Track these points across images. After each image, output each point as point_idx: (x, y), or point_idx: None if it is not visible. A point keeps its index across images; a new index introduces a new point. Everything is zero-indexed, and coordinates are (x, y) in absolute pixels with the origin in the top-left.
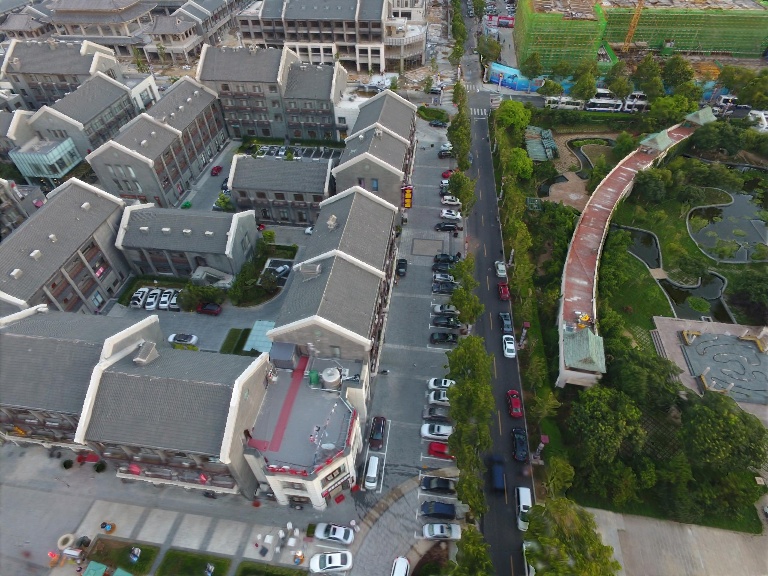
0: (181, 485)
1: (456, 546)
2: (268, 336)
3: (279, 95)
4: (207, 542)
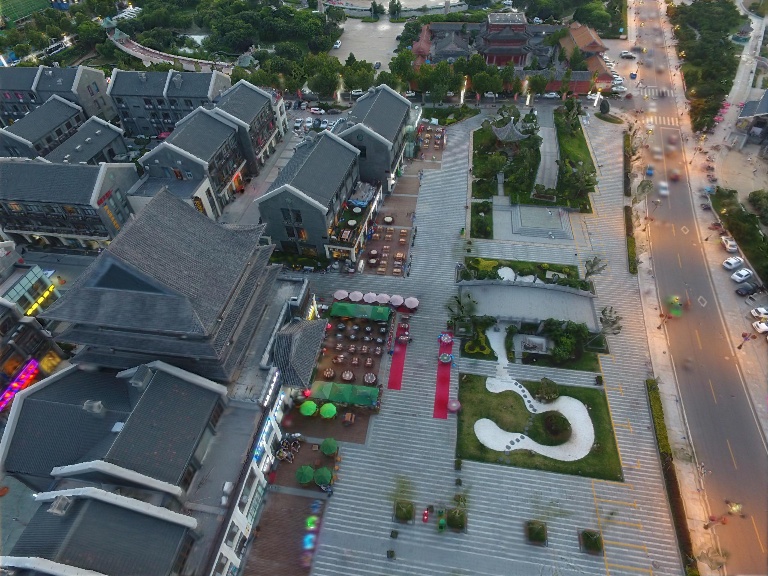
0: None
1: None
2: (210, 97)
3: None
4: None
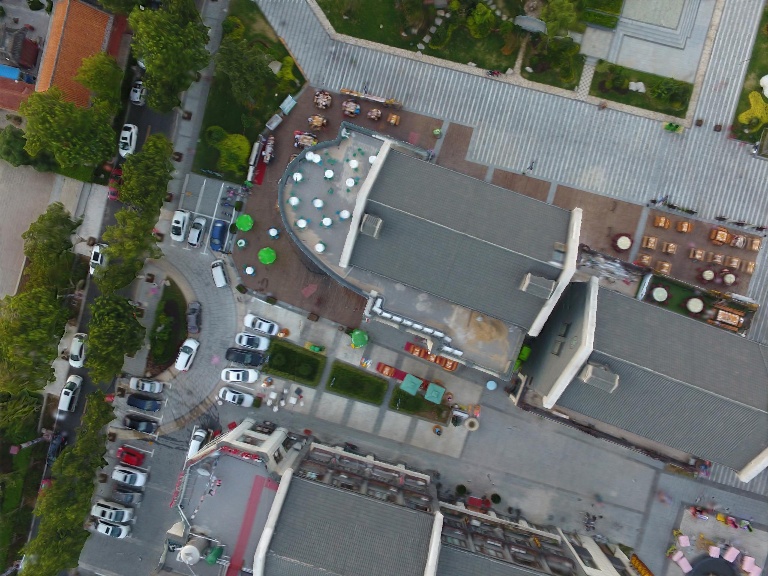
0: (365, 458)
1: (138, 373)
2: None
3: None
4: (349, 406)
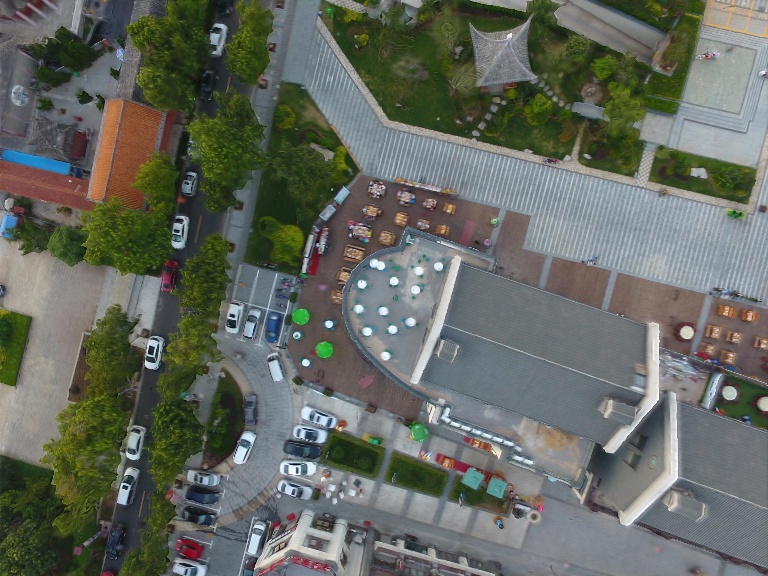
0: (429, 557)
1: (195, 464)
2: None
3: None
4: (408, 497)
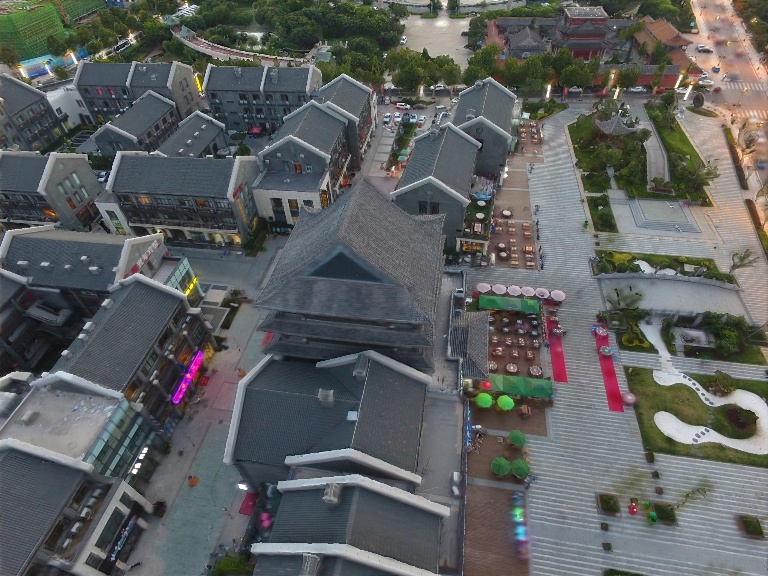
0: None
1: None
2: (308, 92)
3: (6, 116)
4: None
